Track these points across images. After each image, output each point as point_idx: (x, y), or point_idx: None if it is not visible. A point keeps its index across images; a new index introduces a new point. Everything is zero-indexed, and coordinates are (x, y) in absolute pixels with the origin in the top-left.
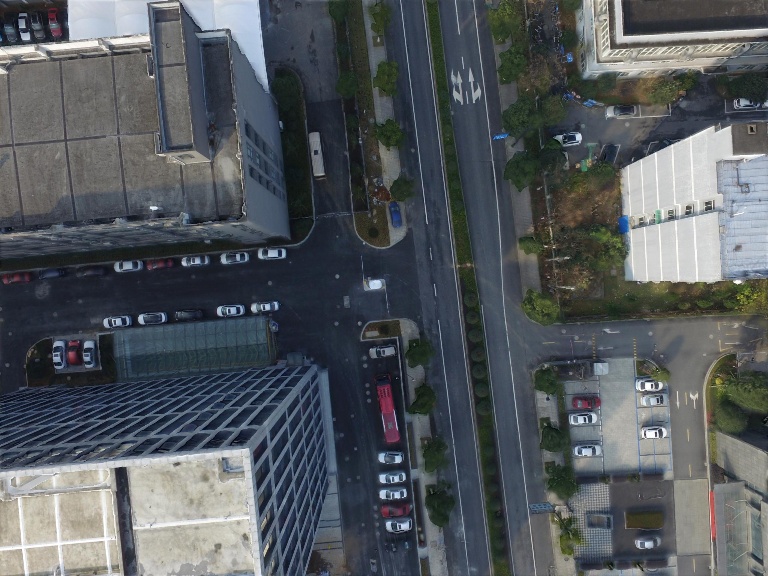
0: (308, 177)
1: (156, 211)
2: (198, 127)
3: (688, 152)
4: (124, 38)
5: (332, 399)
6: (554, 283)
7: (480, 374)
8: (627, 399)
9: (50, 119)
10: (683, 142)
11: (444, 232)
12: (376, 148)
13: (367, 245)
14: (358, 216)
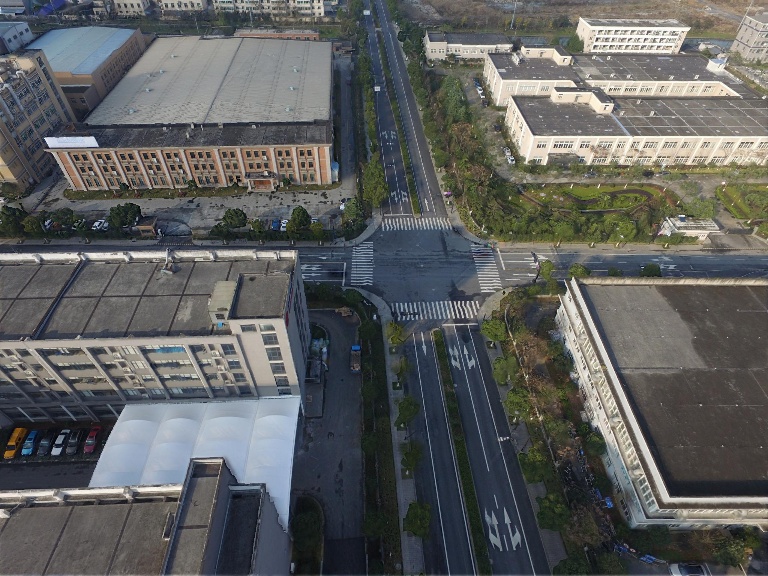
0: None
1: None
2: None
3: None
4: (153, 487)
5: None
6: None
7: None
8: None
9: None
10: None
11: None
12: None
13: None
14: None
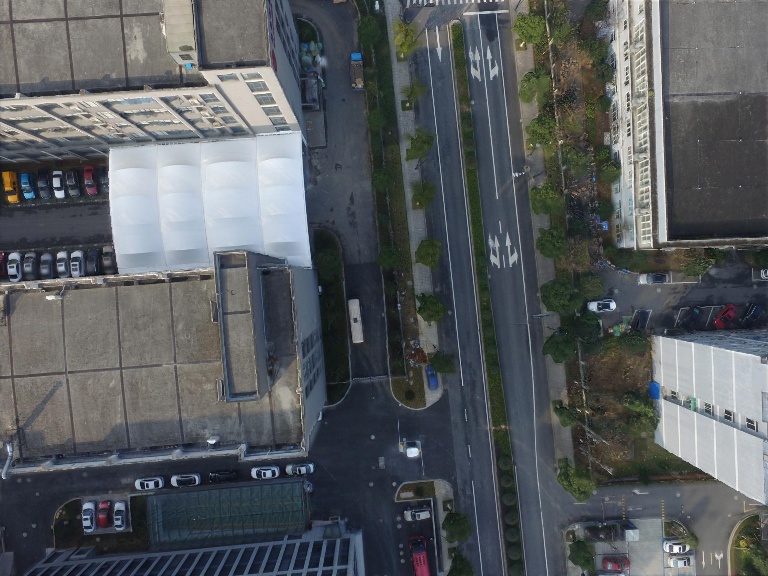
0: (345, 339)
1: None
2: (261, 370)
3: (730, 364)
4: (184, 271)
5: (365, 559)
6: (586, 446)
7: (514, 538)
8: (655, 559)
9: (105, 346)
10: (724, 351)
11: (479, 394)
12: (413, 310)
13: (403, 406)
14: (395, 378)
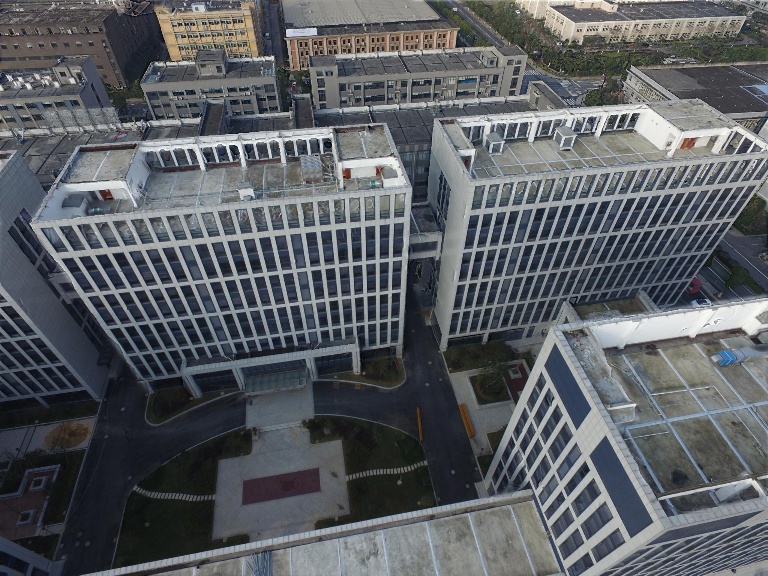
0: None
1: None
2: None
3: (767, 131)
4: (514, 96)
5: None
6: None
7: (727, 254)
8: None
9: None
10: (761, 131)
11: None
12: None
13: None
14: None
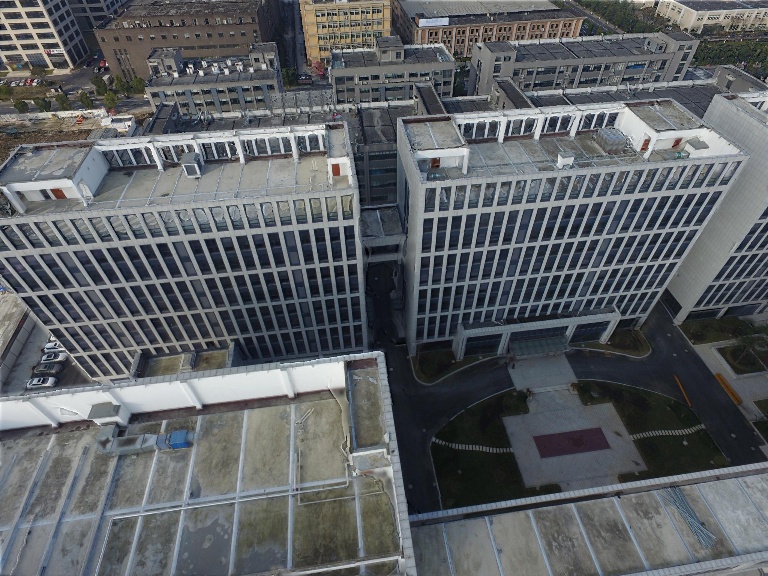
0: None
1: None
2: None
3: None
4: (701, 80)
5: None
6: None
7: None
8: None
9: None
10: None
11: None
12: None
13: None
14: None
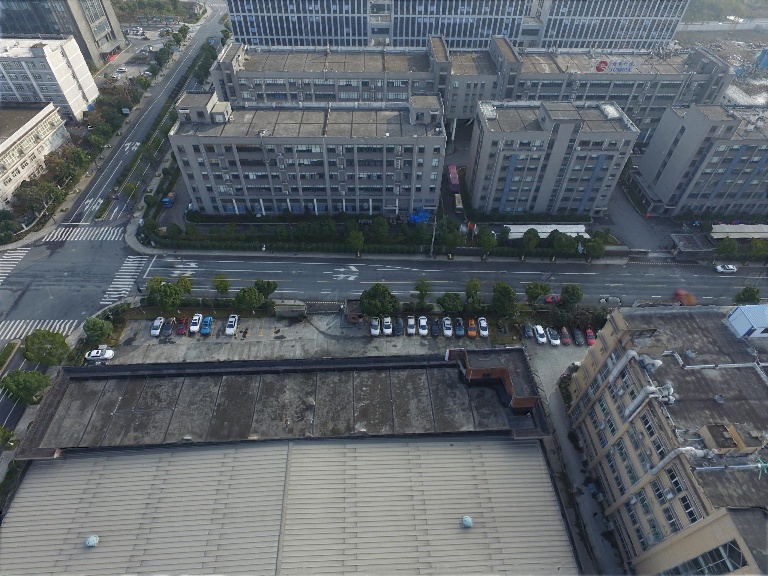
0: None
1: (260, 51)
2: None
3: (56, 71)
4: None
5: None
6: None
7: None
8: None
9: None
10: None
11: None
12: None
13: None
14: None
